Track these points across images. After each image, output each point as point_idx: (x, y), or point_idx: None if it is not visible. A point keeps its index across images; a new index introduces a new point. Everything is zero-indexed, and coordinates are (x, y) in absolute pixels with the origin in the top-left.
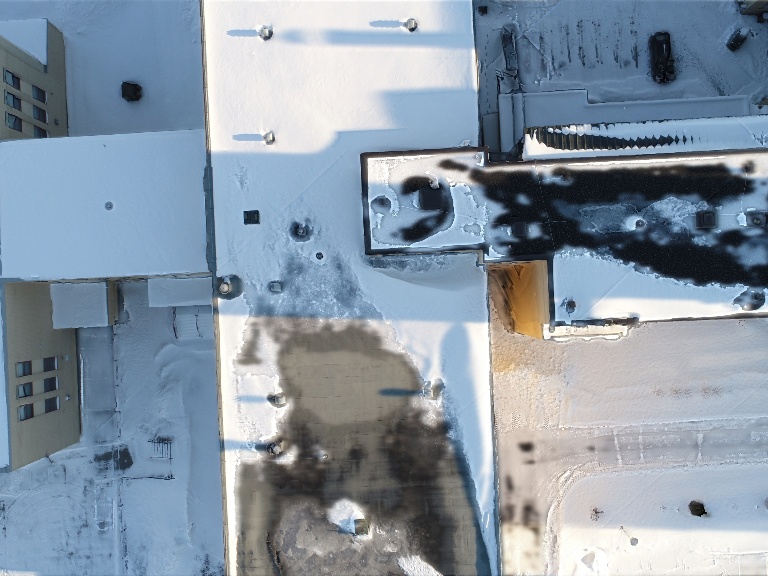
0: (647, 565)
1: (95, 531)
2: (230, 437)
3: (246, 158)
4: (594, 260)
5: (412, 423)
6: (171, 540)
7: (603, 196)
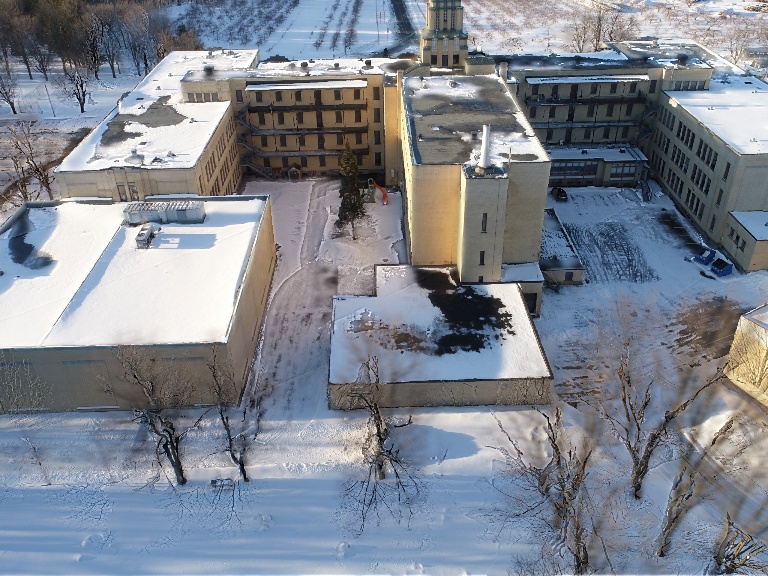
0: None
1: None
2: None
3: None
4: None
5: None
6: None
7: None
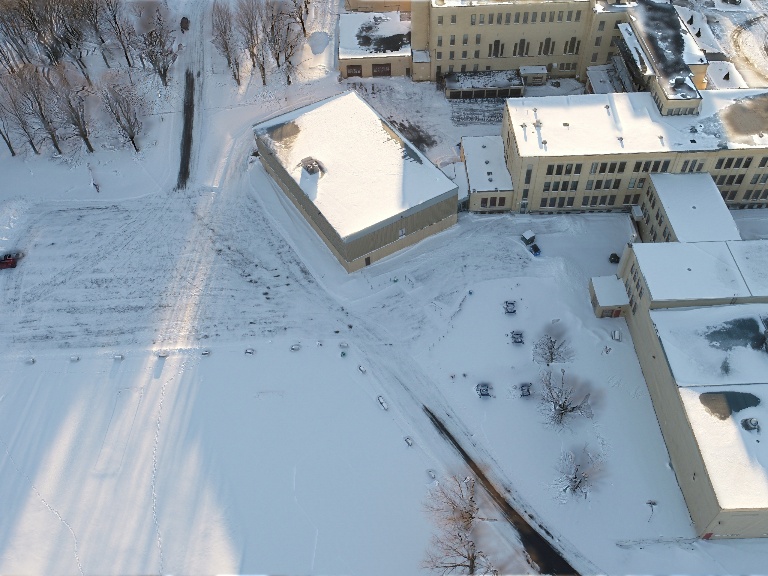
0: None
1: None
2: None
3: None
4: None
5: (753, 106)
6: None
7: None
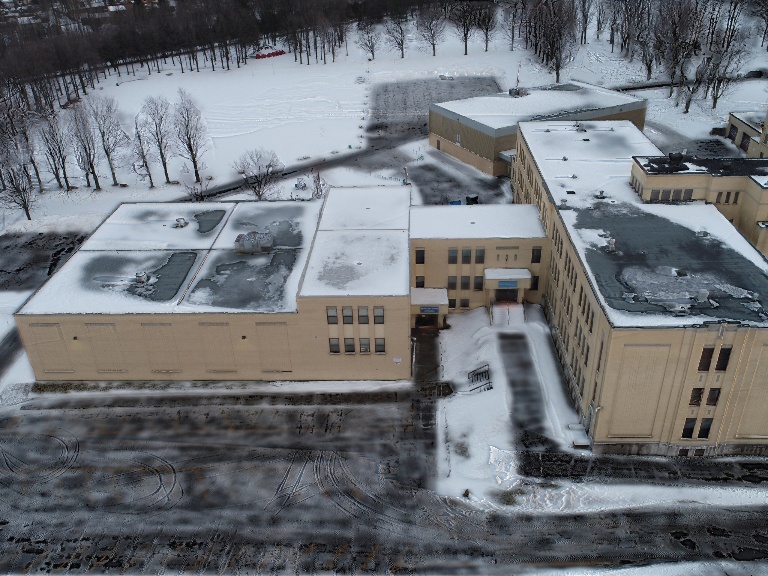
0: None
1: (420, 428)
2: (578, 245)
3: (563, 181)
4: None
5: None
6: (493, 421)
7: None
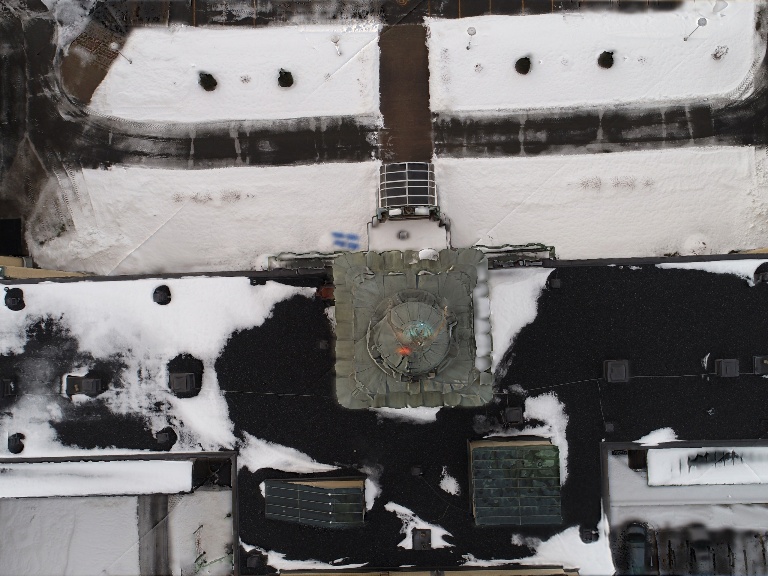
0: (651, 1)
1: None
2: None
3: None
4: None
5: None
6: None
7: None
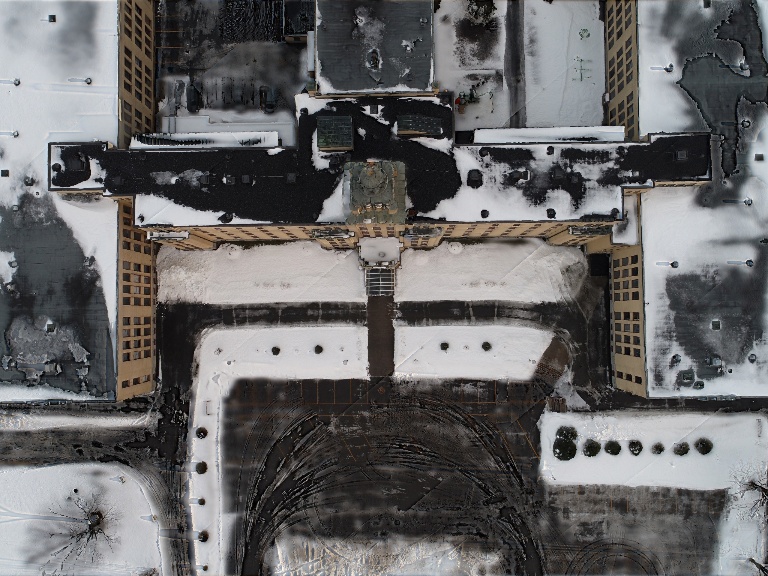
0: (251, 384)
1: None
2: None
3: (4, 144)
4: (155, 197)
5: (79, 278)
6: None
7: (161, 167)
